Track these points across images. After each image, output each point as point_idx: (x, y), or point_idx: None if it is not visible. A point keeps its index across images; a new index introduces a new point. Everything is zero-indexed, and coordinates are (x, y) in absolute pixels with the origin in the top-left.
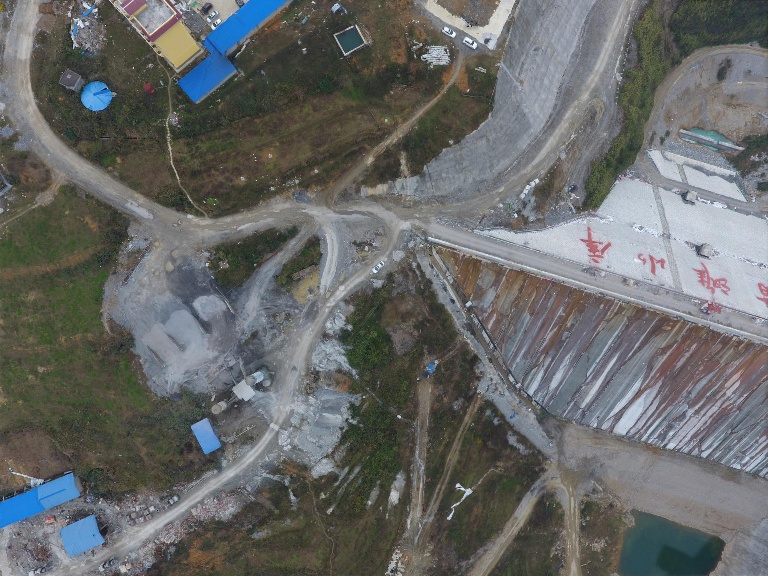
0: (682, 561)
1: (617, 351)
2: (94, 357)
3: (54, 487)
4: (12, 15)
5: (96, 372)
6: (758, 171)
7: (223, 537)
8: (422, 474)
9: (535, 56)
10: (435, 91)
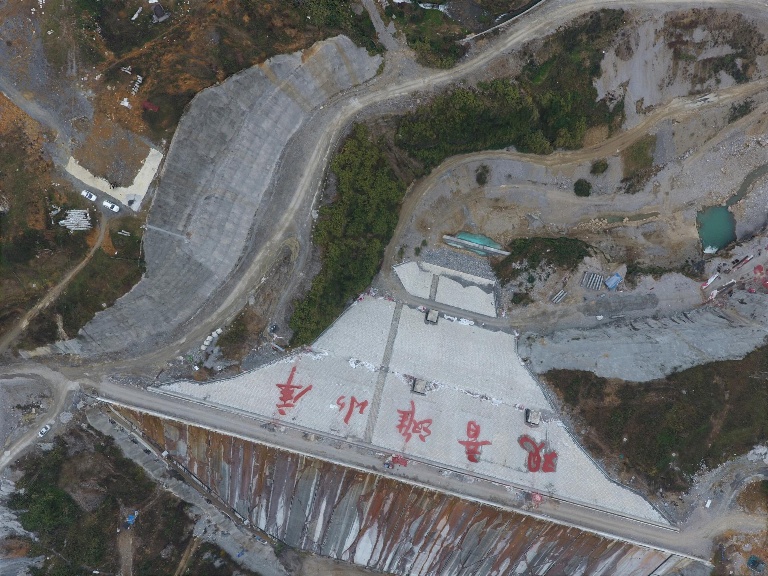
0: None
1: (323, 496)
2: None
3: None
4: None
5: None
6: (517, 280)
7: None
8: None
9: (206, 205)
10: (82, 254)
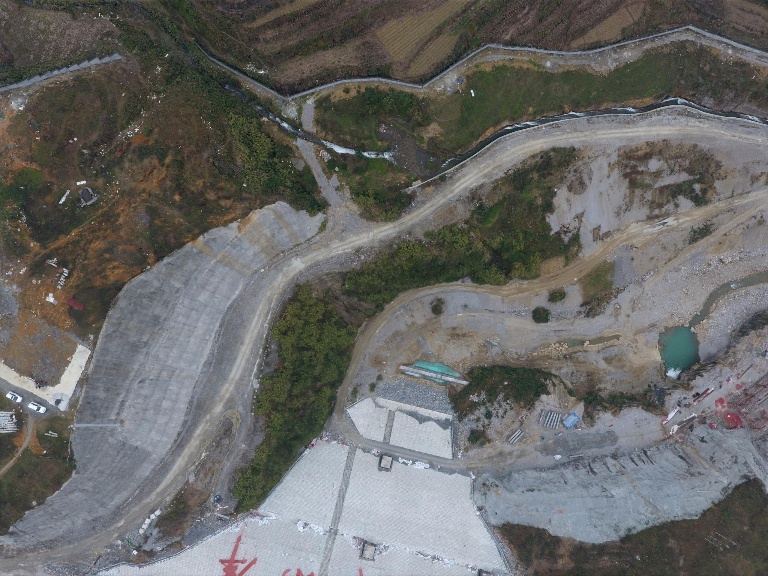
0: None
1: None
2: None
3: None
4: None
5: None
6: (474, 414)
7: None
8: None
9: (140, 389)
10: (9, 454)
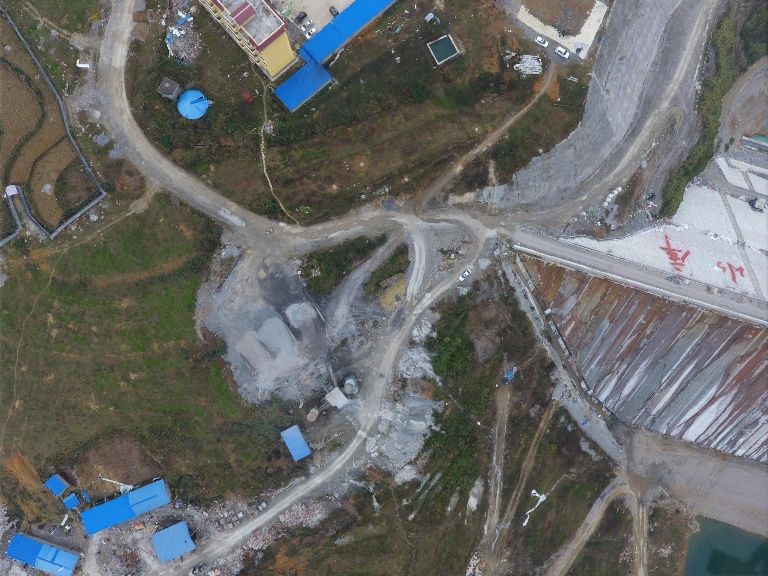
0: (746, 567)
1: (695, 358)
2: (186, 364)
3: (145, 493)
4: (106, 23)
5: (187, 379)
6: None
7: (308, 543)
8: (499, 480)
9: (620, 65)
10: (526, 100)
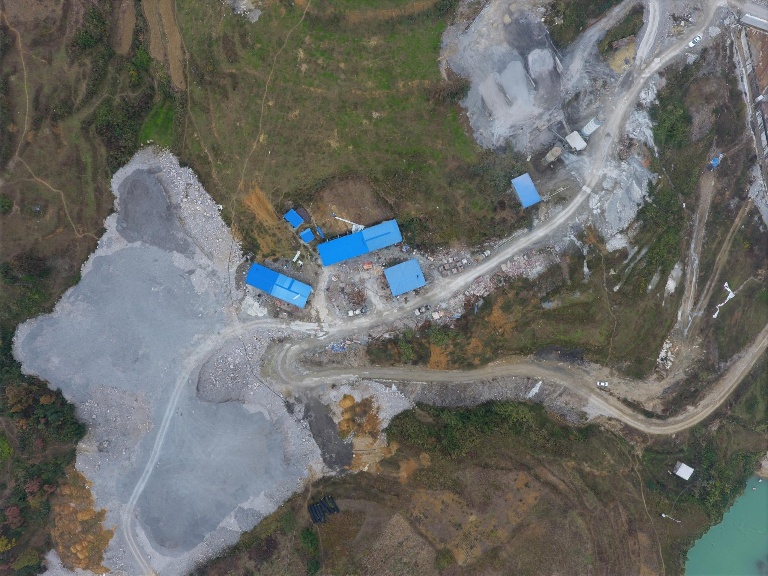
0: None
1: None
2: (426, 106)
3: (379, 230)
4: None
5: (426, 121)
6: None
7: (523, 299)
8: (696, 268)
9: None
10: None
